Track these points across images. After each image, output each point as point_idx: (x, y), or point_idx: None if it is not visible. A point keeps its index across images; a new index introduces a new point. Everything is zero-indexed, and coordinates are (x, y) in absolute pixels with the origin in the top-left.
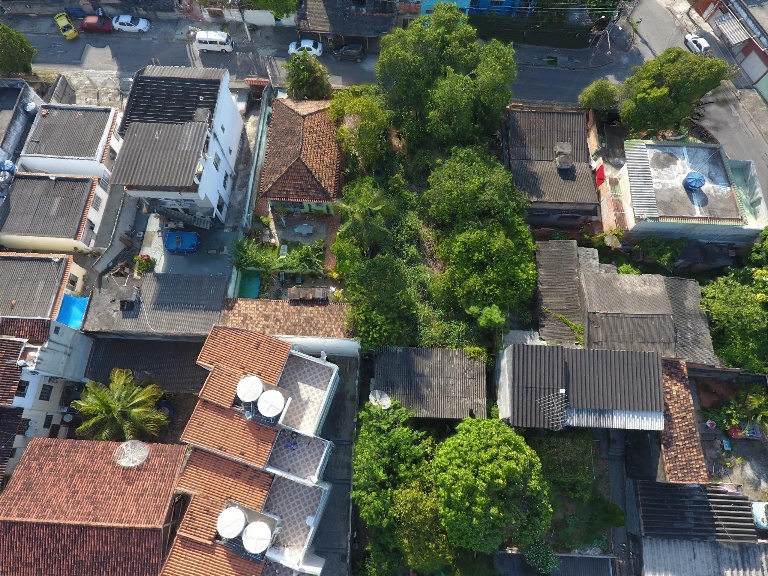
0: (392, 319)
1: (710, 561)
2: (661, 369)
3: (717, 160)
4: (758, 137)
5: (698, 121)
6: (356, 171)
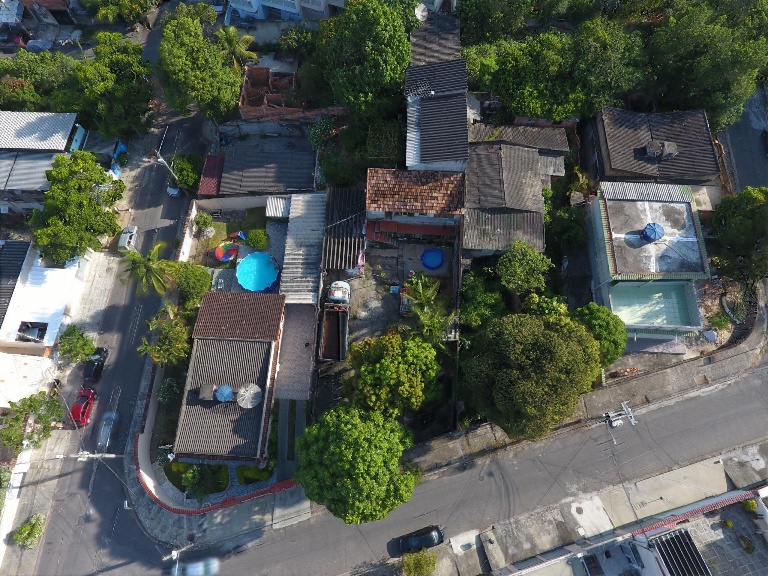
0: (479, 7)
1: (309, 239)
2: (455, 159)
3: (688, 268)
4: (763, 433)
5: (766, 362)
6: (607, 6)
